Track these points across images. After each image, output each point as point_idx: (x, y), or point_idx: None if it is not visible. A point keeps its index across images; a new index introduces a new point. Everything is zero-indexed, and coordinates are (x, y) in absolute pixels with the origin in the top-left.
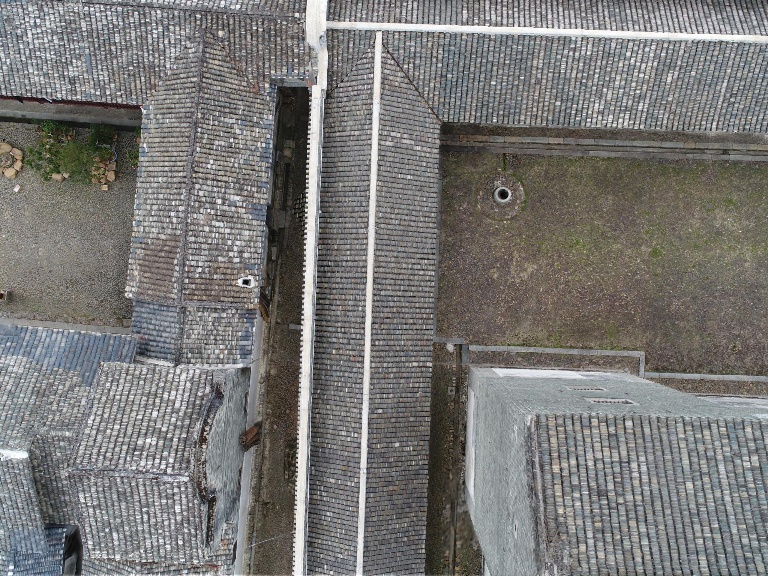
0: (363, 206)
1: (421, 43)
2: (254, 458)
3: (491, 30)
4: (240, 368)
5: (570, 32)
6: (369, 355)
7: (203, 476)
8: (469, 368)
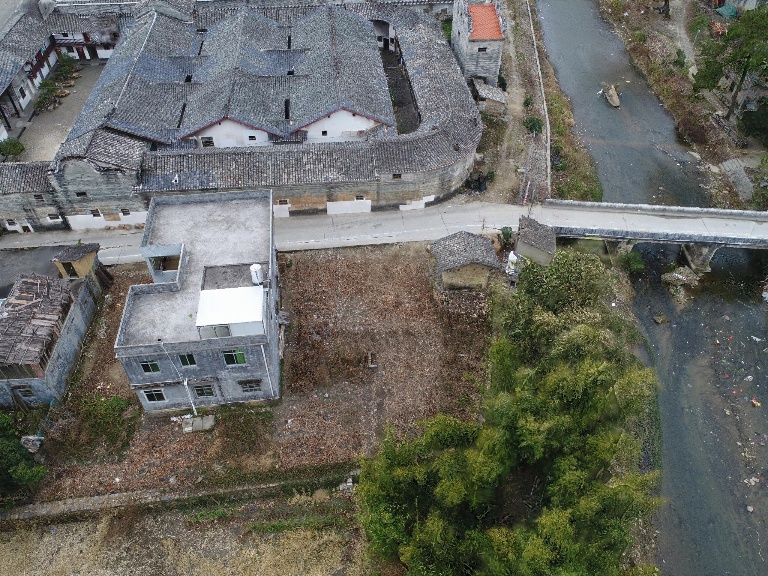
0: (97, 2)
1: None
2: None
3: None
4: None
5: None
6: None
7: None
8: None
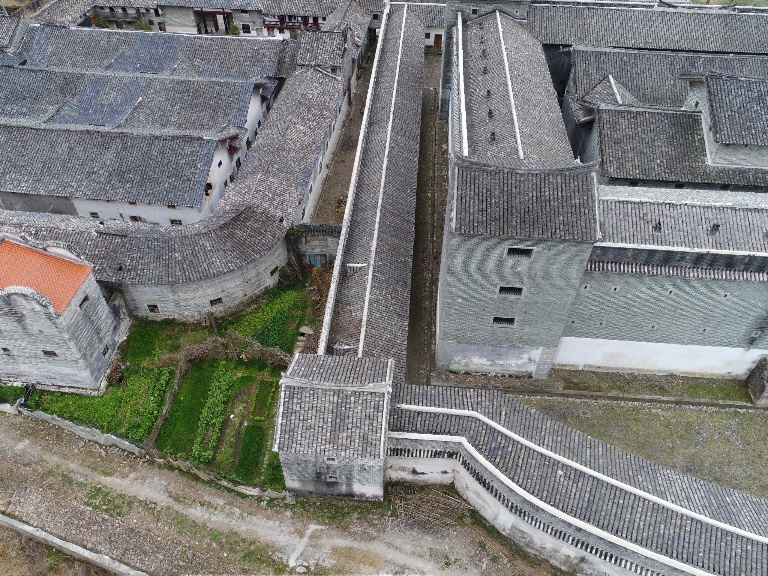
0: None
1: (419, 7)
2: (347, 109)
3: (441, 4)
4: (352, 57)
5: None
6: (401, 47)
7: (347, 30)
8: (439, 88)
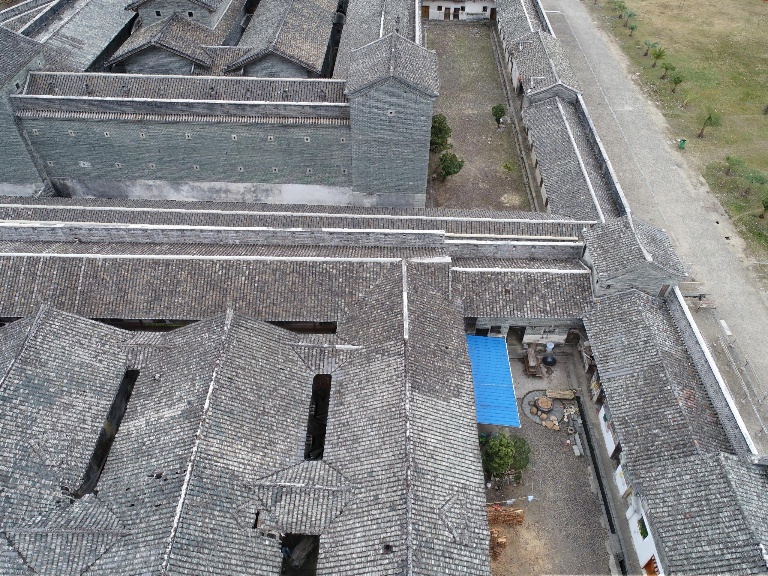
0: None
1: None
2: None
3: None
4: None
5: (522, 2)
6: None
7: None
8: None
